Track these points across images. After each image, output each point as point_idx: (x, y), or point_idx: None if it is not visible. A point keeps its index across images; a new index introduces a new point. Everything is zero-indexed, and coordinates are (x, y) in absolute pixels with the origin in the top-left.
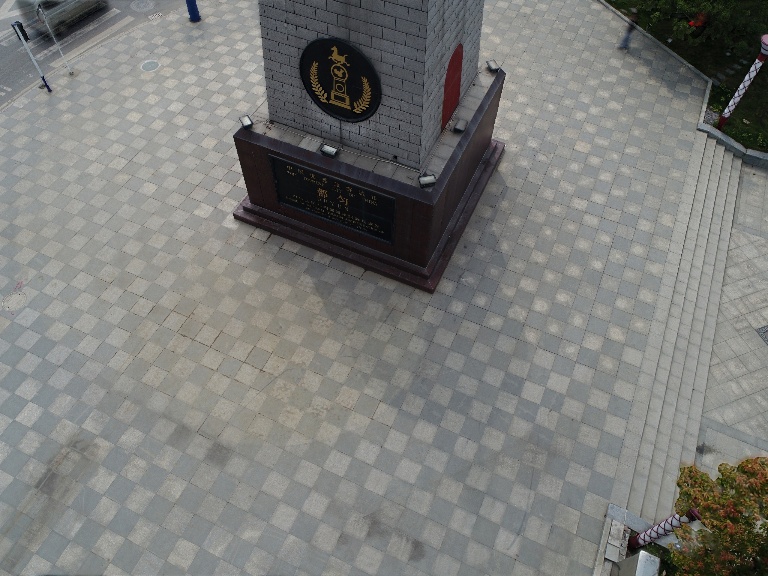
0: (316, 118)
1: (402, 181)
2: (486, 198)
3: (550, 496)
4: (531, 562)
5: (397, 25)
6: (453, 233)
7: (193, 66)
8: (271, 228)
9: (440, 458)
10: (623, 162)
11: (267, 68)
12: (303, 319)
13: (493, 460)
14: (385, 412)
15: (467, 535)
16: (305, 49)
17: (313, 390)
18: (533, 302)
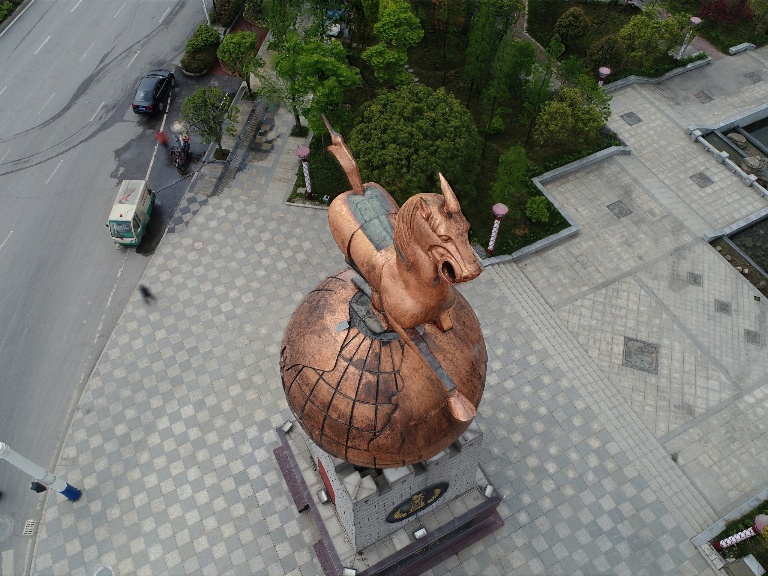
0: None
1: (476, 505)
2: None
3: (672, 568)
4: None
5: None
6: None
7: (140, 539)
8: None
9: None
10: None
11: None
12: None
13: None
14: None
15: None
16: None
17: None
18: (546, 469)
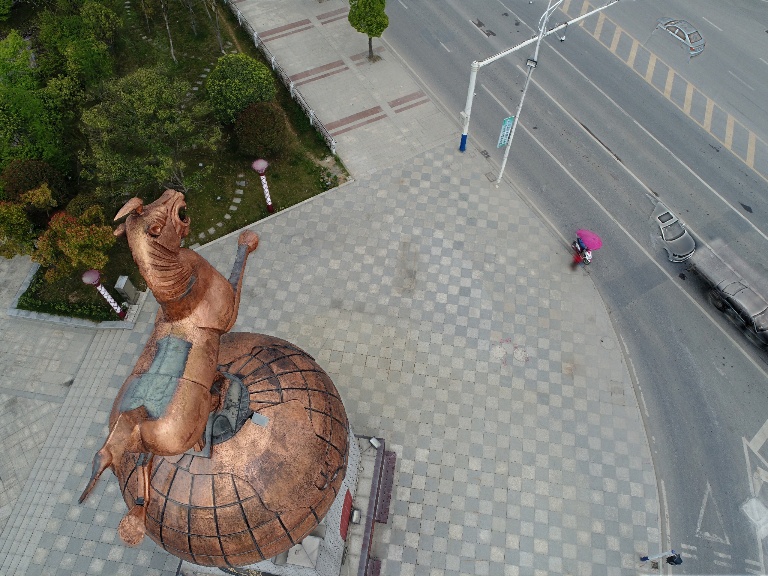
0: None
1: None
2: None
3: None
4: None
5: None
6: None
7: None
8: None
9: None
10: None
11: None
12: None
13: None
14: None
15: None
16: None
17: None
18: None
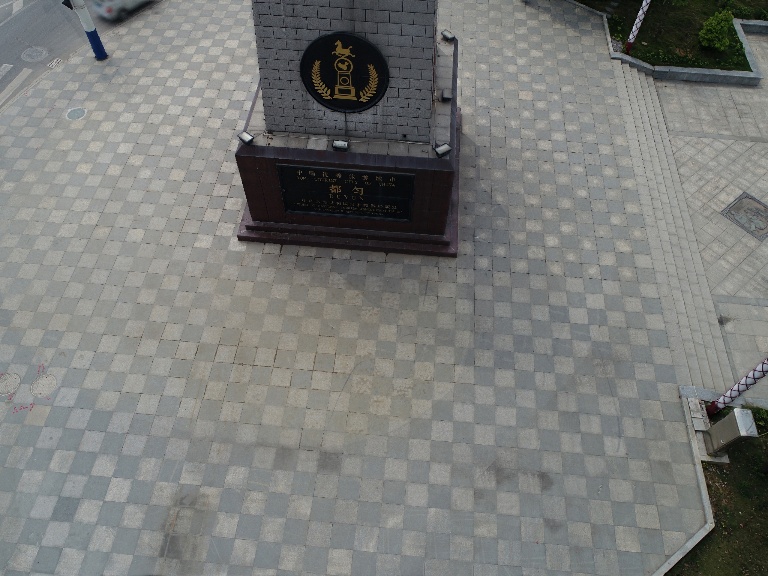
0: (319, 117)
1: (419, 156)
2: (464, 160)
3: (630, 396)
4: (640, 455)
5: (404, 6)
6: (452, 198)
7: (123, 104)
8: (281, 239)
9: (528, 396)
10: (564, 100)
11: (263, 78)
12: (350, 314)
13: (572, 383)
14: (463, 373)
15: (580, 452)
16: (306, 50)
17: (390, 375)
18: (544, 240)
